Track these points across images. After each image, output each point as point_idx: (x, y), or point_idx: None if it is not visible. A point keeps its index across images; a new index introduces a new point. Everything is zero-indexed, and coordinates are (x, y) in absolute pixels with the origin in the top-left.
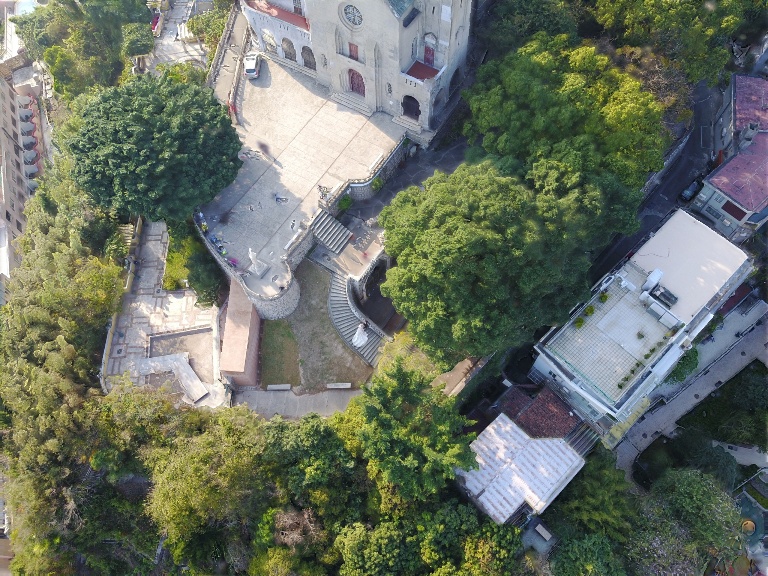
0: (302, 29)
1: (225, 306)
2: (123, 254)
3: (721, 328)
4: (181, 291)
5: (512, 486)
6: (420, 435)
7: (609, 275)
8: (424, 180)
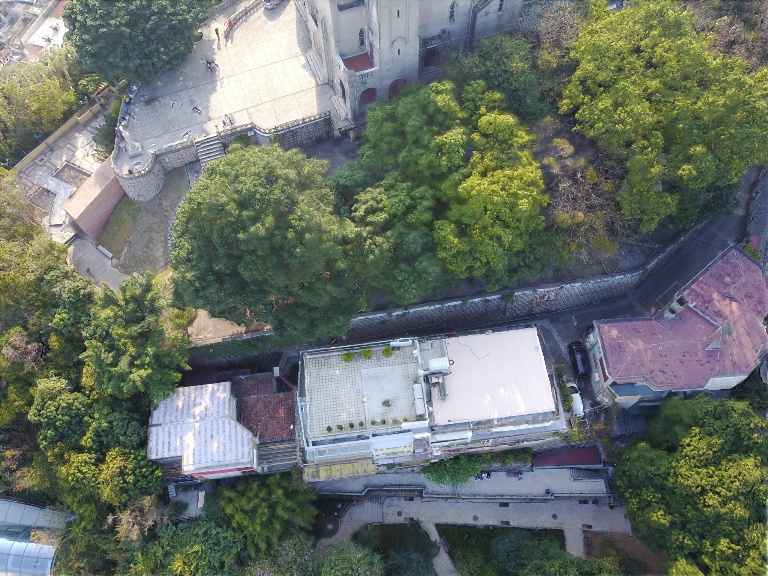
0: None
1: None
2: (90, 92)
3: (520, 468)
4: None
5: (183, 438)
6: (133, 344)
7: (415, 339)
8: None
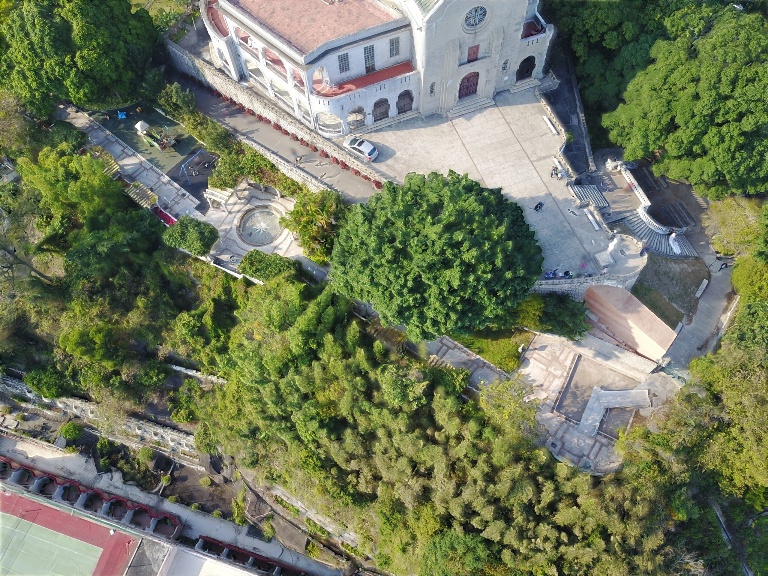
0: (403, 75)
1: None
2: None
3: None
4: (521, 360)
5: None
6: None
7: None
8: (567, 116)
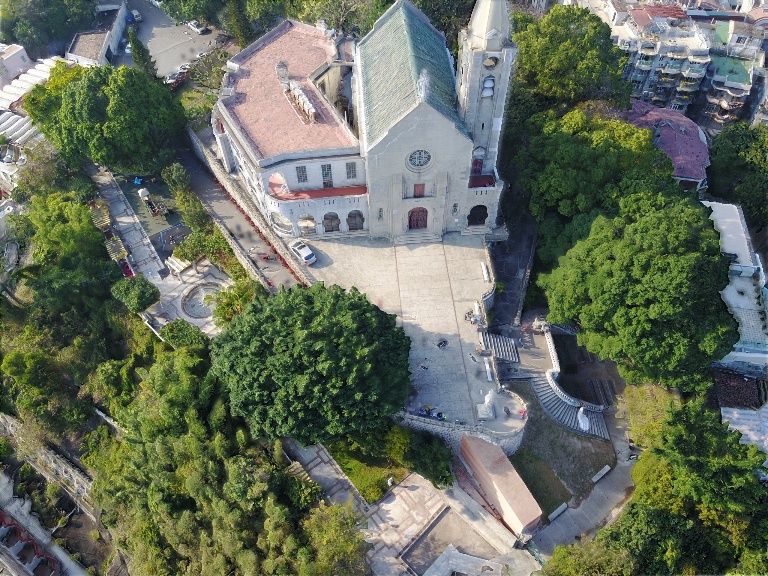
0: (352, 196)
1: (454, 474)
2: None
3: None
4: (388, 494)
5: None
6: (719, 457)
7: None
8: (514, 269)
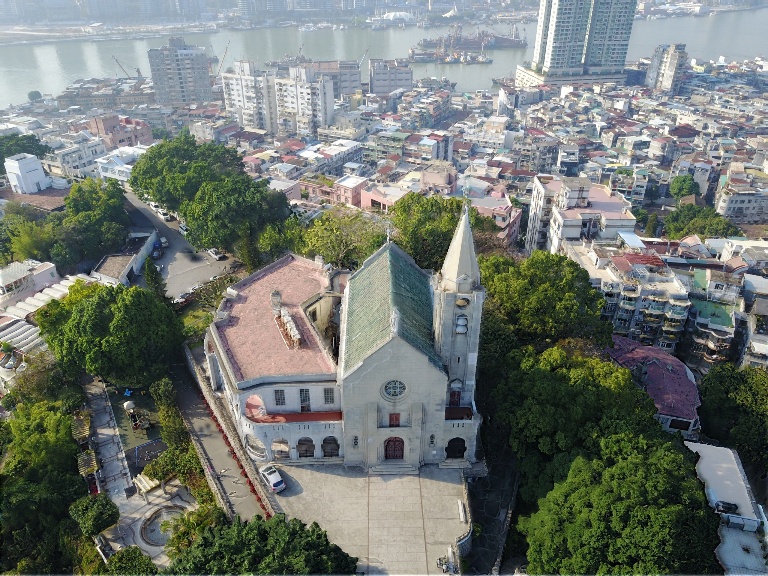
0: (327, 422)
1: None
2: None
3: None
4: None
5: None
6: None
7: None
8: (495, 508)
